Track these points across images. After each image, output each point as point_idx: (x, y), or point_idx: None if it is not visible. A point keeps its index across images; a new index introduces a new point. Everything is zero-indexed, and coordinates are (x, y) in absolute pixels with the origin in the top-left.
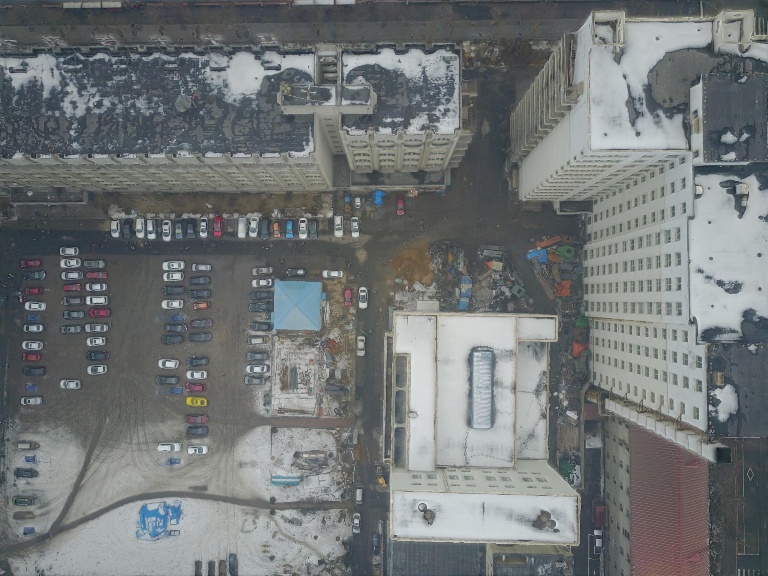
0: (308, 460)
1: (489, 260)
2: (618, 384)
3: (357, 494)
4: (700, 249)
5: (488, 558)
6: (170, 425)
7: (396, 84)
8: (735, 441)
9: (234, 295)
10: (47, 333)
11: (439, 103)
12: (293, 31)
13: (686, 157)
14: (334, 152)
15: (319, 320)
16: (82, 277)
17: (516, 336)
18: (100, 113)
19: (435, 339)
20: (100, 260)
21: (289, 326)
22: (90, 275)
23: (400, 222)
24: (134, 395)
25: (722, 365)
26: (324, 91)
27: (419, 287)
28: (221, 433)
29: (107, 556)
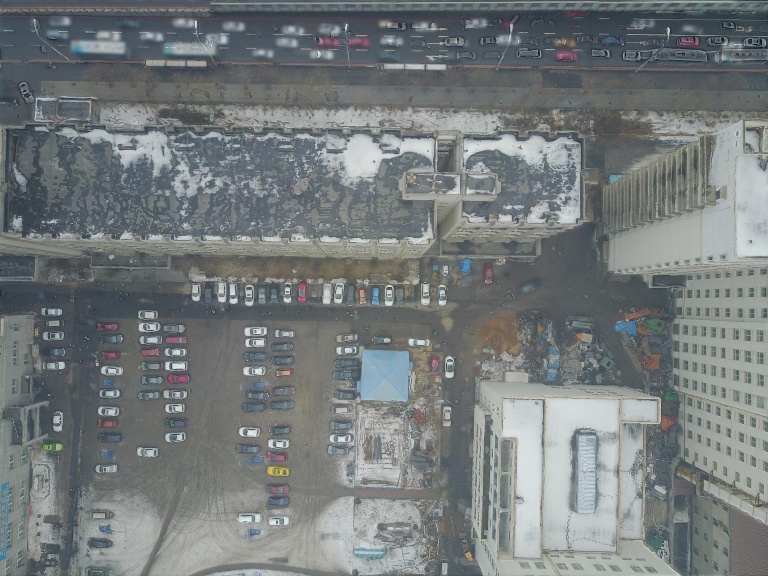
0: (392, 532)
1: (578, 331)
2: (722, 469)
3: (442, 568)
4: None
5: None
6: (250, 495)
7: (517, 171)
8: None
9: (317, 362)
10: (123, 398)
11: (560, 191)
12: (381, 94)
13: None
14: None
15: (407, 391)
16: (161, 342)
17: (620, 419)
18: (212, 193)
19: (542, 423)
20: (180, 325)
21: (377, 397)
22: (170, 340)
23: (487, 290)
24: (213, 463)
25: None
26: (448, 179)
27: (506, 357)
28: (302, 503)
29: None
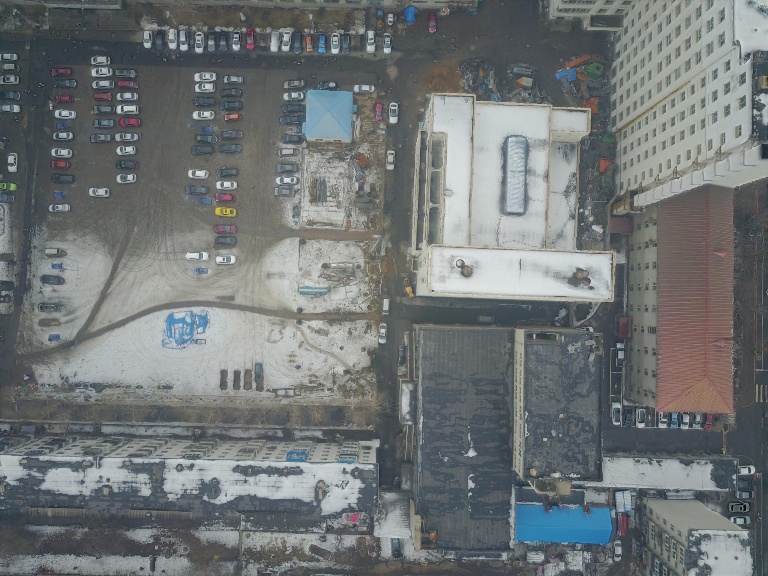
0: (336, 271)
1: (519, 77)
2: (649, 172)
3: (384, 303)
4: None
5: (517, 344)
6: (198, 235)
7: None
8: (755, 260)
9: (265, 108)
10: (76, 142)
11: None
12: None
13: None
14: None
15: (350, 129)
16: (113, 86)
17: (550, 125)
18: None
19: (471, 120)
20: (132, 70)
21: (321, 133)
22: (122, 83)
23: (432, 40)
24: (163, 205)
25: (767, 71)
26: None
27: None
28: (249, 244)
29: (132, 364)
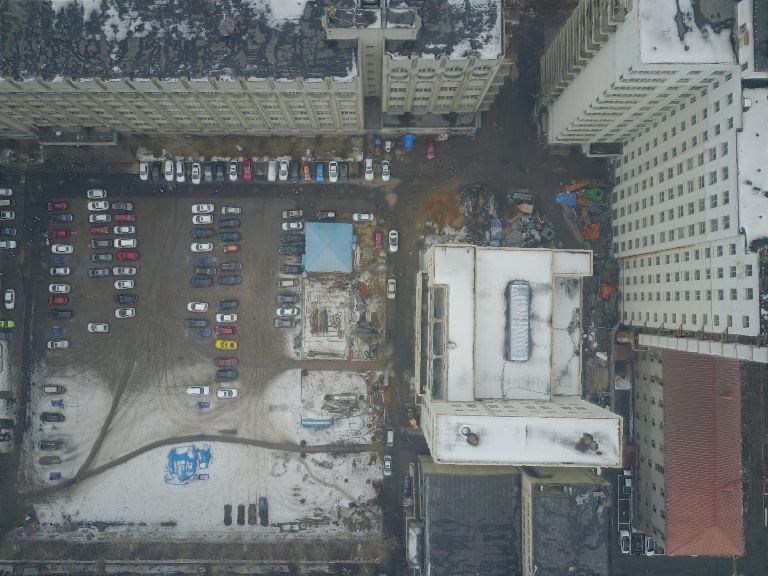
0: (339, 403)
1: (519, 203)
2: (653, 316)
3: (388, 436)
4: (748, 161)
5: (524, 491)
6: (199, 369)
7: (439, 10)
8: (761, 382)
9: (264, 238)
10: (74, 276)
11: (482, 30)
12: None
13: (733, 72)
14: (366, 93)
15: (351, 261)
16: (110, 220)
17: (552, 269)
18: (141, 37)
19: (473, 270)
20: (128, 203)
21: (321, 267)
22: (118, 217)
23: (430, 166)
24: (163, 339)
25: None
26: (369, 14)
27: (449, 230)
28: (251, 376)
29: (135, 501)
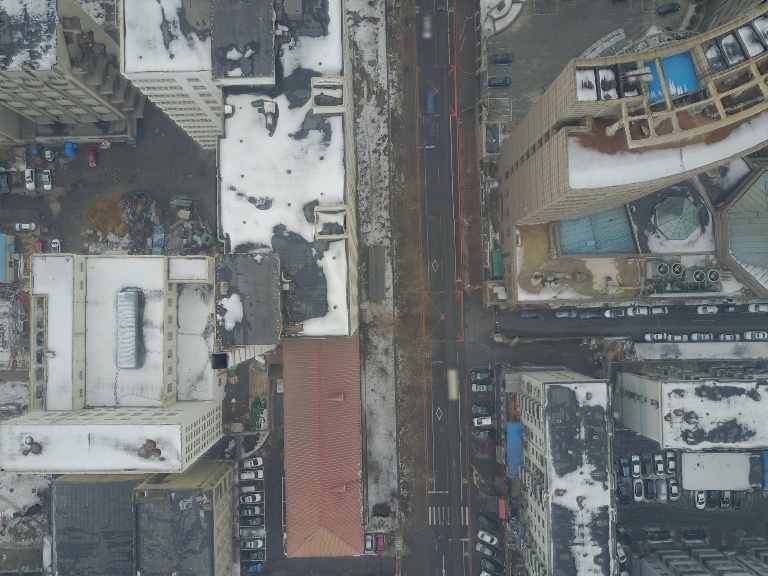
0: (2, 413)
1: (178, 209)
2: None
3: None
4: (232, 167)
5: None
6: None
7: None
8: (424, 381)
9: None
10: None
11: (41, 40)
12: None
13: None
14: None
15: (4, 272)
16: None
17: (164, 276)
18: None
19: (72, 279)
20: None
21: None
22: None
23: (93, 174)
24: None
25: (228, 275)
26: None
27: (112, 238)
28: None
29: None
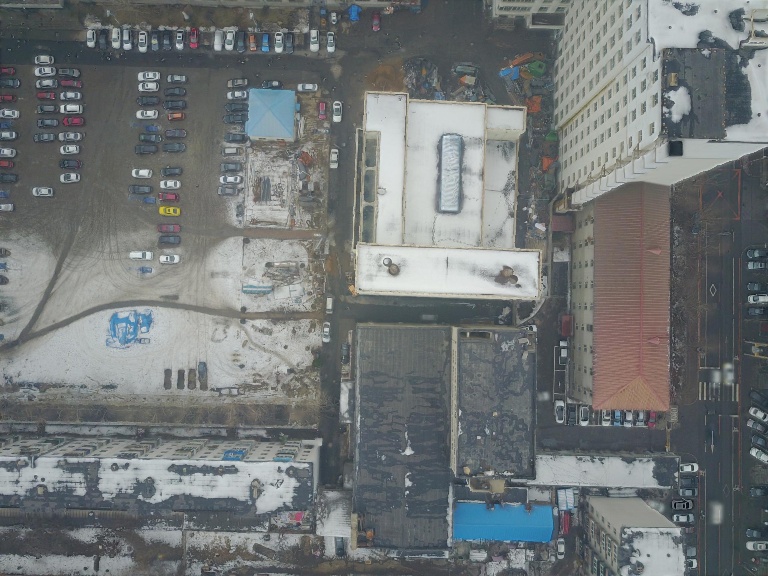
0: (279, 270)
1: (462, 75)
2: (583, 170)
3: (327, 302)
4: None
5: (453, 342)
6: (142, 235)
7: None
8: (699, 258)
9: (209, 107)
10: (20, 142)
11: None
12: None
13: None
14: None
15: (293, 128)
16: (57, 86)
17: (485, 123)
18: None
19: (405, 118)
20: (75, 69)
21: (263, 132)
22: (65, 83)
23: (375, 39)
24: (107, 204)
25: (676, 68)
26: None
27: None
28: (193, 243)
29: (76, 363)
